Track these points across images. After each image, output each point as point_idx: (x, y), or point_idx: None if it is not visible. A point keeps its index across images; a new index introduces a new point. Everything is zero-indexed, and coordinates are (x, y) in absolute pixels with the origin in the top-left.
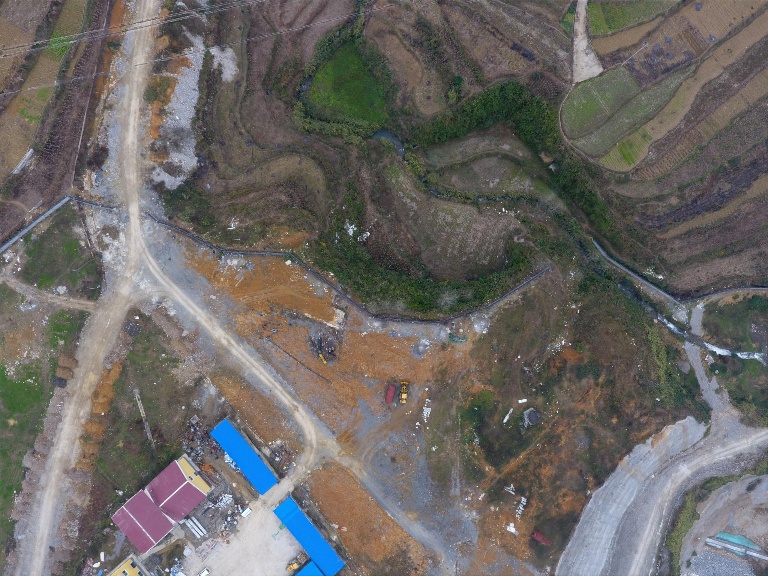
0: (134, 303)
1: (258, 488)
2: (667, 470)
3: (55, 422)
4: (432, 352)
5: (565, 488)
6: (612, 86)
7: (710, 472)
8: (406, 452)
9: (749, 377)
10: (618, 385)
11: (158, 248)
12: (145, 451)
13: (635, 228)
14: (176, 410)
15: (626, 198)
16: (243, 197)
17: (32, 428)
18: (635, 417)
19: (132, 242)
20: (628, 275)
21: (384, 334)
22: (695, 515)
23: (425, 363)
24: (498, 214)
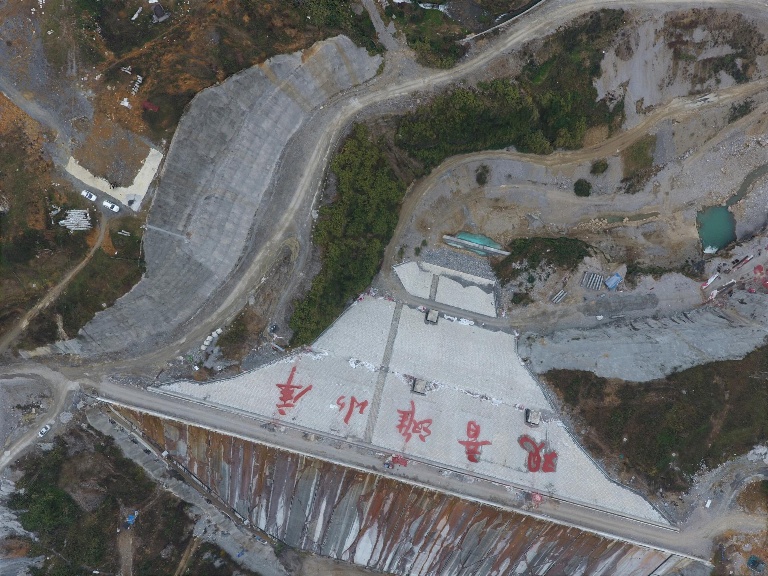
0: None
1: None
2: (336, 102)
3: None
4: None
5: (188, 73)
6: None
7: (383, 107)
8: (22, 36)
9: (431, 26)
10: None
11: None
12: None
13: None
14: None
15: None
16: None
17: None
18: (276, 25)
19: None
20: None
21: None
22: (398, 179)
23: None
24: None
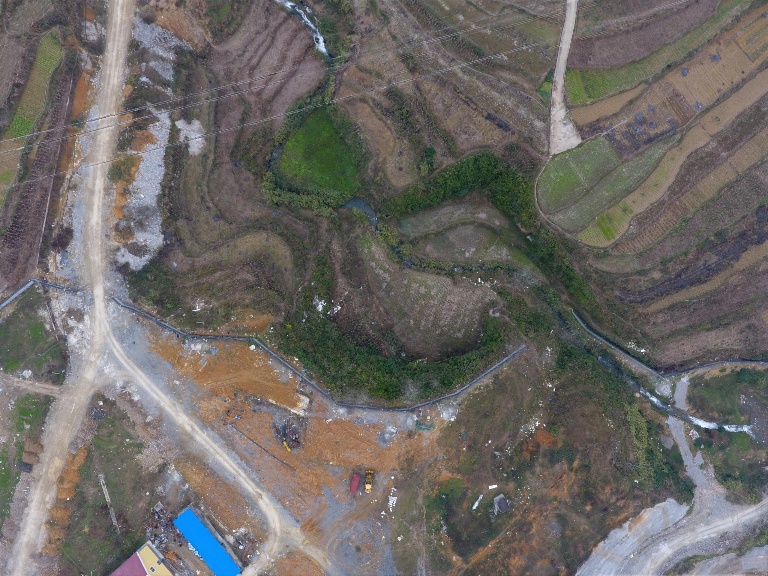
0: (98, 388)
1: None
2: (647, 550)
3: (21, 507)
4: (398, 440)
5: None
6: (591, 158)
7: (692, 551)
8: (371, 541)
9: (736, 451)
10: (593, 469)
11: (122, 331)
12: (110, 536)
13: (615, 303)
14: (140, 496)
15: (605, 274)
16: (209, 276)
17: None
18: (611, 502)
19: (97, 325)
20: (609, 347)
21: (349, 421)
22: None
23: (391, 451)
24: (474, 285)
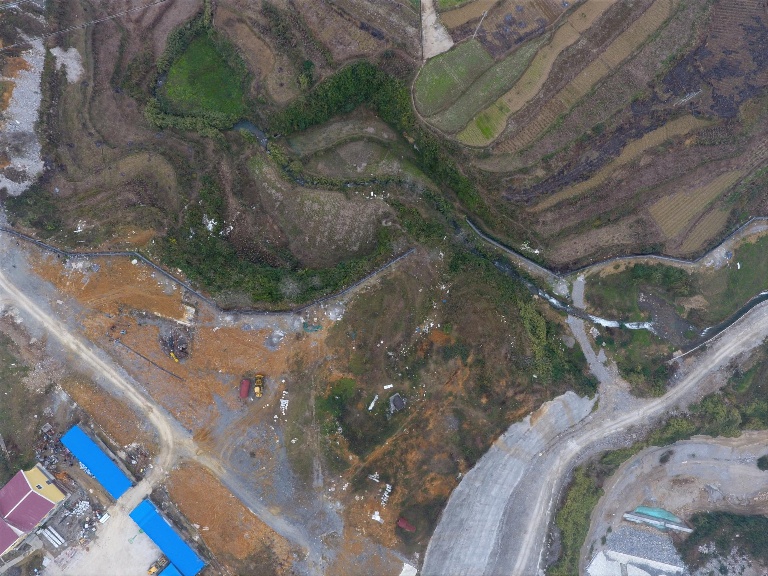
0: None
1: (112, 493)
2: (555, 447)
3: None
4: (286, 343)
5: (433, 472)
6: (464, 60)
7: (600, 446)
8: (265, 446)
9: (639, 347)
10: (488, 364)
11: (2, 256)
12: None
13: (502, 203)
14: (28, 419)
15: (487, 173)
16: (91, 198)
17: None
18: (509, 395)
19: None
20: (504, 252)
21: (236, 328)
22: (599, 491)
23: (280, 355)
24: (366, 199)
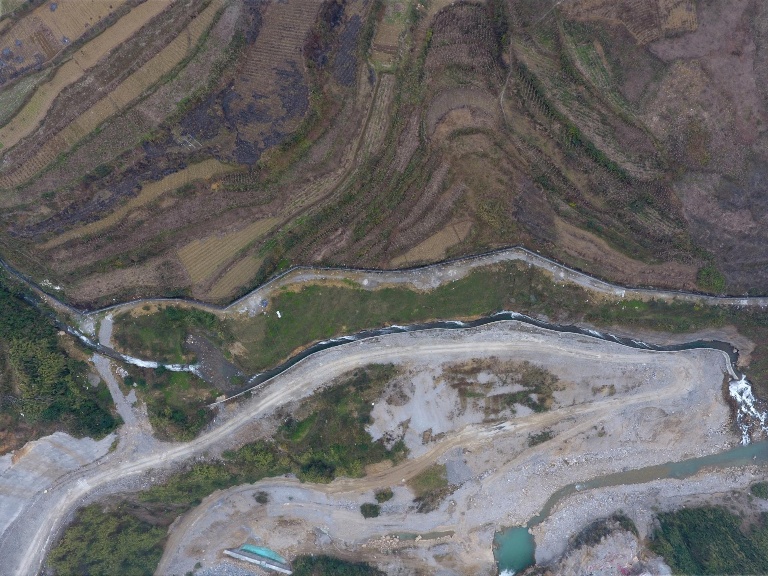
0: None
1: None
2: (61, 485)
3: None
4: None
5: None
6: None
7: (113, 487)
8: None
9: (177, 390)
10: None
11: None
12: None
13: (5, 239)
14: None
15: None
16: None
17: None
18: None
19: None
20: (31, 286)
21: None
22: (152, 529)
23: None
24: None
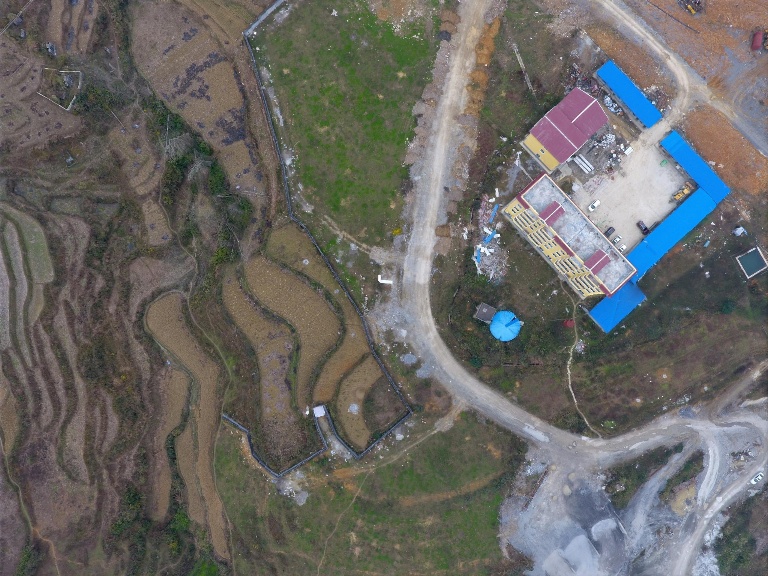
0: None
1: (645, 122)
2: None
3: (444, 71)
4: None
5: None
6: None
7: None
8: None
9: None
10: None
11: None
12: (526, 100)
13: None
14: (554, 61)
15: None
16: None
17: (420, 80)
18: None
19: None
20: None
21: None
22: None
23: None
24: None
